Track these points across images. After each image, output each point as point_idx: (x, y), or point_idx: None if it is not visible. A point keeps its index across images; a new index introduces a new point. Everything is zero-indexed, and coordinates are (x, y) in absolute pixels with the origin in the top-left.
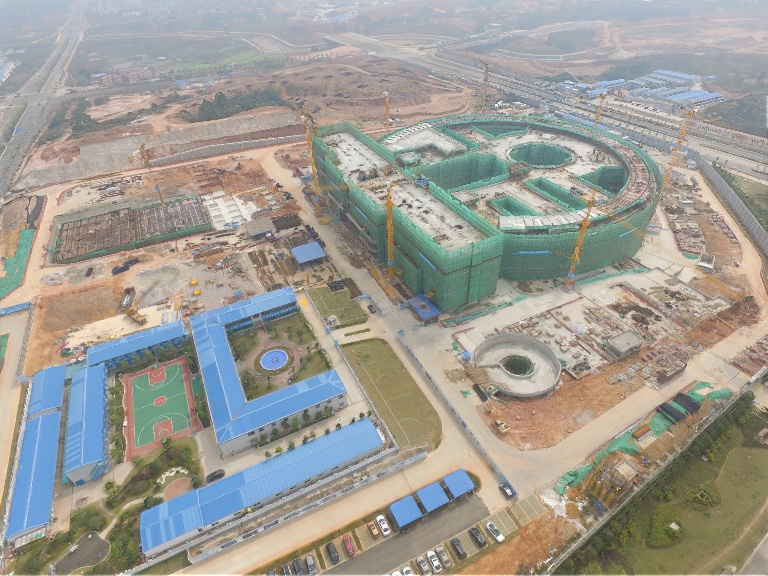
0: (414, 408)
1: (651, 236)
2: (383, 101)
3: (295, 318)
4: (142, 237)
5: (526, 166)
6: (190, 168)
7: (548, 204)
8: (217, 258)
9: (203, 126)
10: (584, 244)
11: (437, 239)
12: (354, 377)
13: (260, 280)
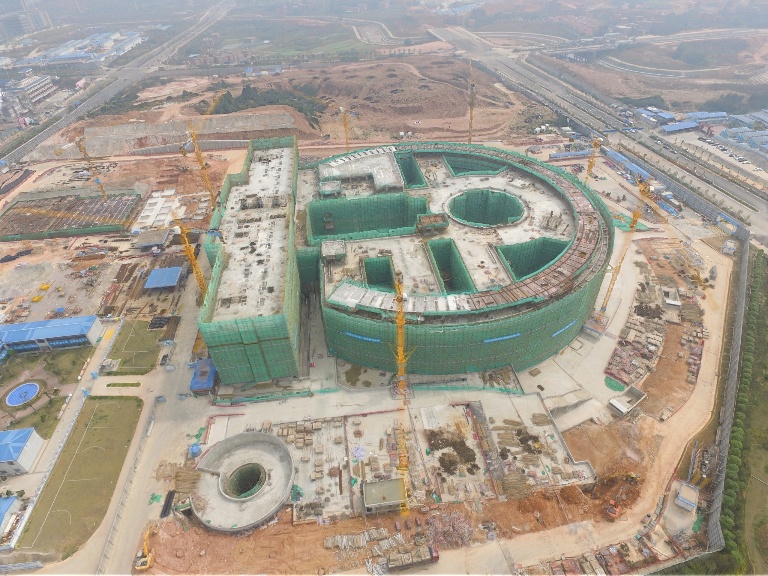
0: (84, 499)
1: (583, 341)
2: (410, 110)
3: (85, 351)
4: (59, 228)
5: (443, 221)
6: (167, 161)
7: (428, 277)
8: (86, 265)
9: (200, 120)
10: (426, 342)
11: (232, 300)
12: (63, 440)
13: (104, 298)
